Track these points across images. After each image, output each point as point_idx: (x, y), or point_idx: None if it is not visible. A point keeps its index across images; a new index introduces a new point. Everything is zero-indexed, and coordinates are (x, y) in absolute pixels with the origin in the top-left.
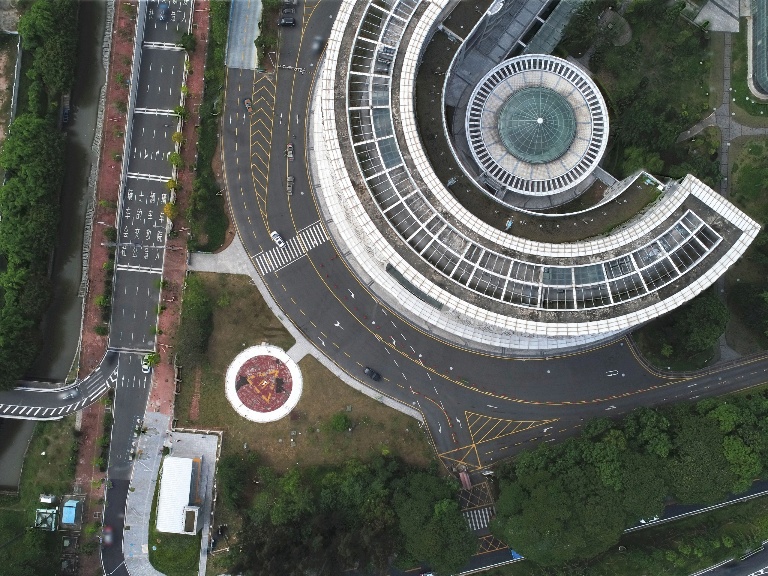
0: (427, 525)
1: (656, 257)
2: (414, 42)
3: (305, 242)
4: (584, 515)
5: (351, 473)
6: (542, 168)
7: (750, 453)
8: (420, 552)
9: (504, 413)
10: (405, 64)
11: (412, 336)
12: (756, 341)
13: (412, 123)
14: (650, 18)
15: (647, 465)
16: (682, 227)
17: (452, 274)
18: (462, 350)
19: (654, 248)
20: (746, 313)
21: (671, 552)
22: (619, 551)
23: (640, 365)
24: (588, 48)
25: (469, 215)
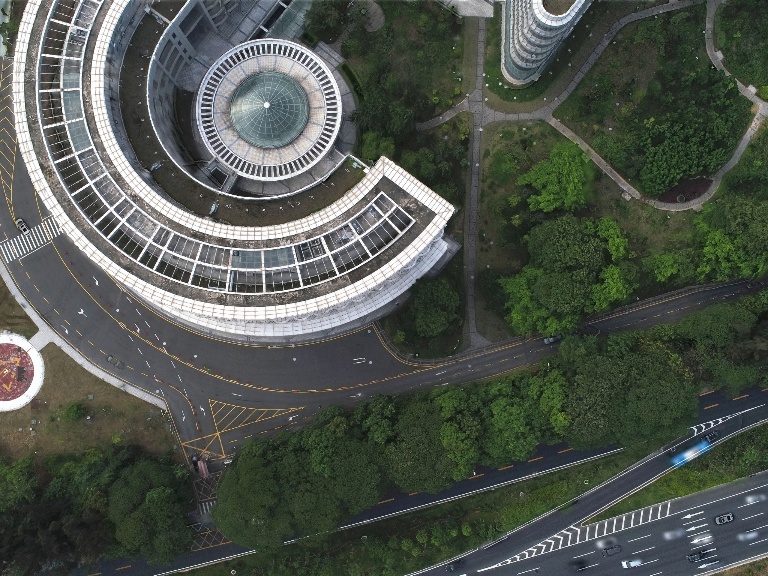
0: (133, 513)
1: (348, 240)
2: (107, 24)
3: (50, 229)
4: (293, 502)
5: (89, 462)
6: (274, 153)
7: (464, 439)
8: (128, 540)
9: (249, 401)
10: (97, 46)
11: (156, 324)
12: (502, 328)
13: (103, 105)
14: (397, 3)
15: (363, 452)
16: (375, 209)
17: (140, 257)
18: (207, 338)
19: (348, 231)
20: (487, 299)
21: (407, 541)
22: (360, 540)
23: (388, 352)
24: (340, 34)
25: (158, 198)
